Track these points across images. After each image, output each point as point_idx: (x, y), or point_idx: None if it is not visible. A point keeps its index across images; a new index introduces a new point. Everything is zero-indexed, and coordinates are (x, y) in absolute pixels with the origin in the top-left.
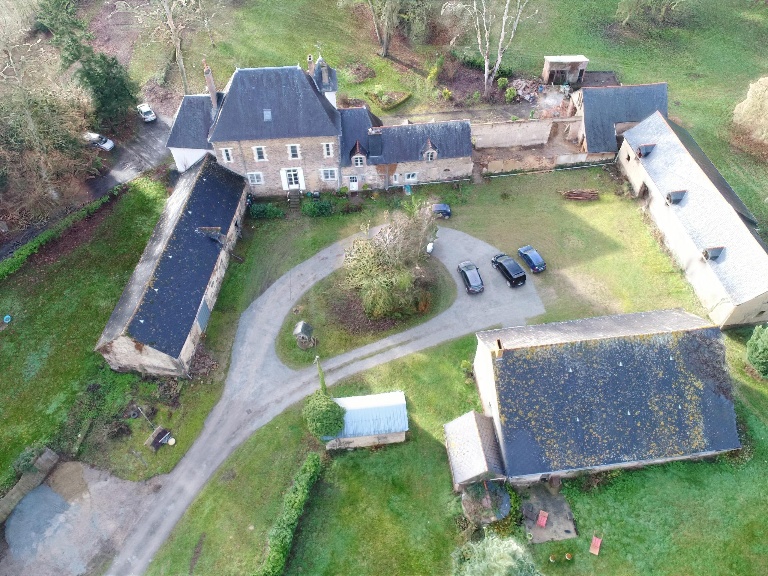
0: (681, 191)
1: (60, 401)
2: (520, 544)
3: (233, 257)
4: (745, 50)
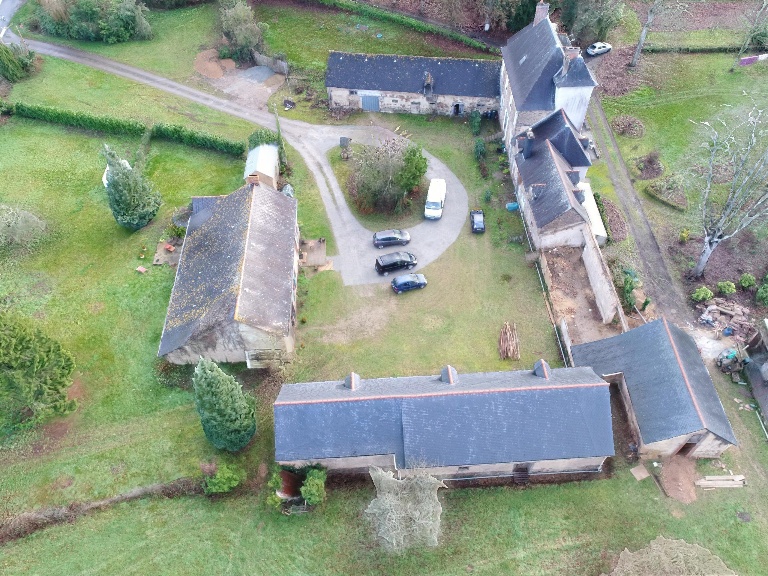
0: (449, 377)
1: (319, 64)
2: None
3: (433, 116)
4: None
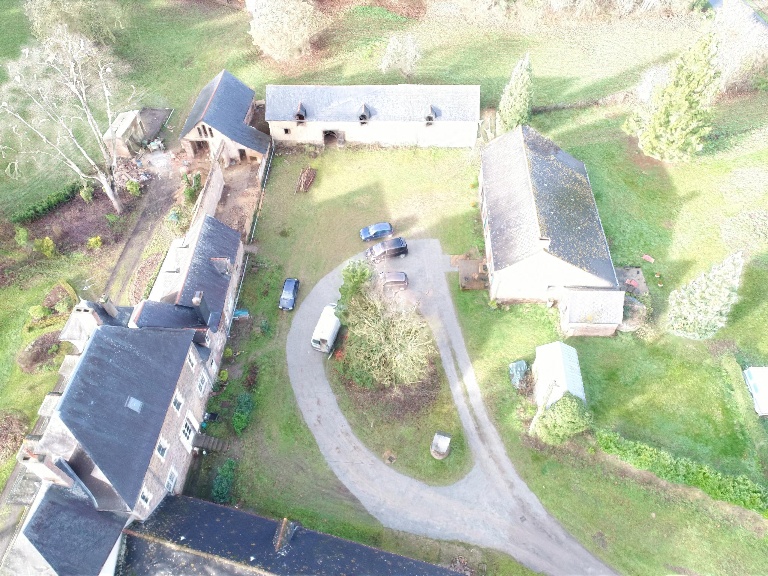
0: (364, 107)
1: None
2: (651, 302)
3: None
4: (172, 26)
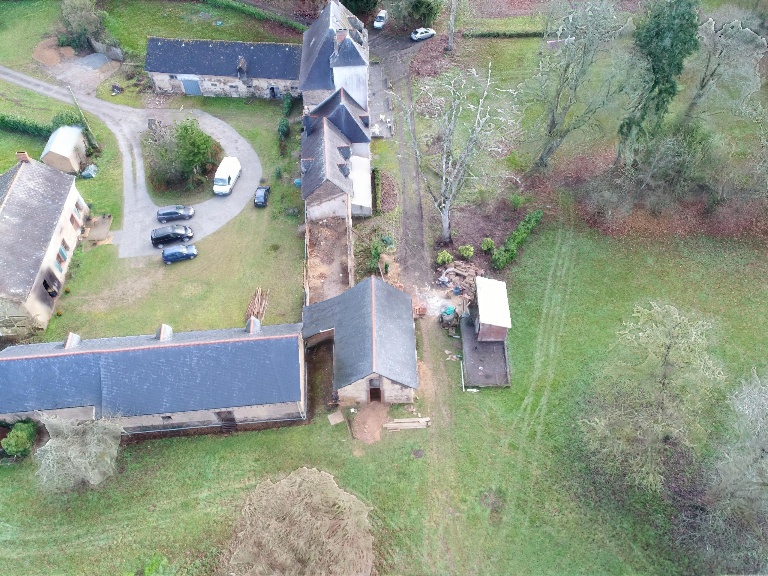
0: (161, 334)
1: None
2: None
3: (252, 99)
4: None
